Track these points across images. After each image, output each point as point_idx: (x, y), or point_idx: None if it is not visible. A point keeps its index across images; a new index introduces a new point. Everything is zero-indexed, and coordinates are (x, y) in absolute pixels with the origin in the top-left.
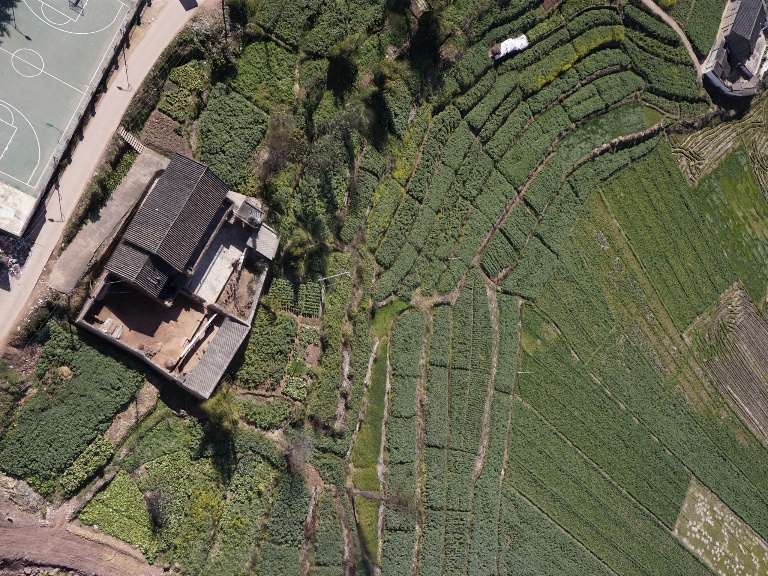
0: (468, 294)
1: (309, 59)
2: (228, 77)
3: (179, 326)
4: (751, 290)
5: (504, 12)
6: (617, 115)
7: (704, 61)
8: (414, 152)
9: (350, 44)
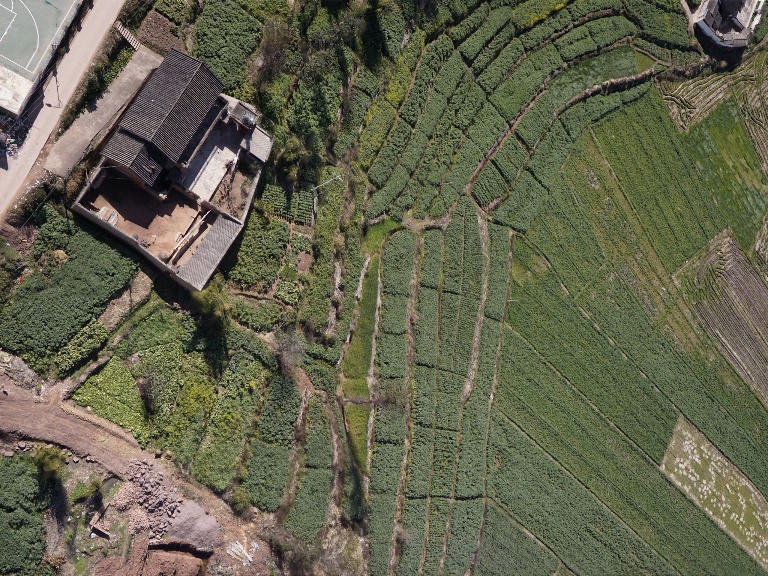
0: (459, 221)
1: None
2: None
3: (173, 221)
4: (740, 238)
5: None
6: (609, 58)
7: (696, 11)
8: (407, 76)
9: None
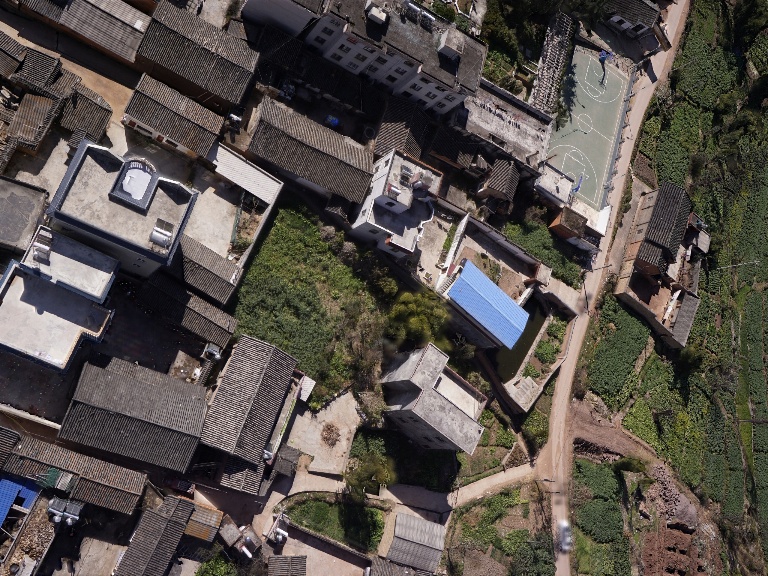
0: None
1: (703, 112)
2: (666, 127)
3: (659, 298)
4: None
5: None
6: None
7: None
8: None
9: None
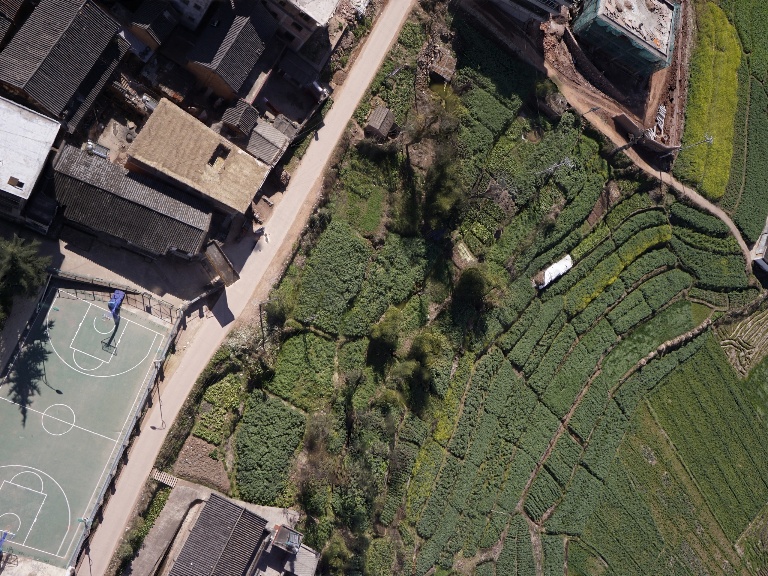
0: (512, 544)
1: (348, 341)
2: (265, 380)
3: None
4: None
5: (548, 239)
6: (664, 318)
7: (753, 246)
8: (456, 408)
9: (392, 329)
